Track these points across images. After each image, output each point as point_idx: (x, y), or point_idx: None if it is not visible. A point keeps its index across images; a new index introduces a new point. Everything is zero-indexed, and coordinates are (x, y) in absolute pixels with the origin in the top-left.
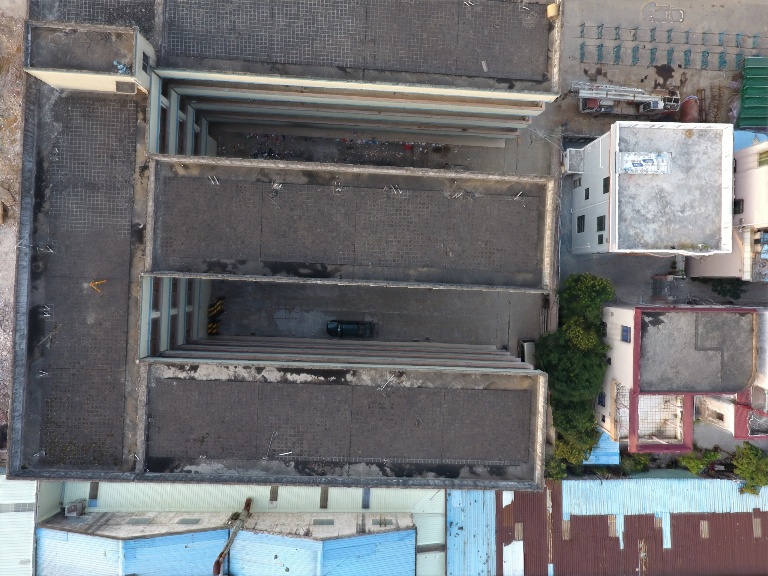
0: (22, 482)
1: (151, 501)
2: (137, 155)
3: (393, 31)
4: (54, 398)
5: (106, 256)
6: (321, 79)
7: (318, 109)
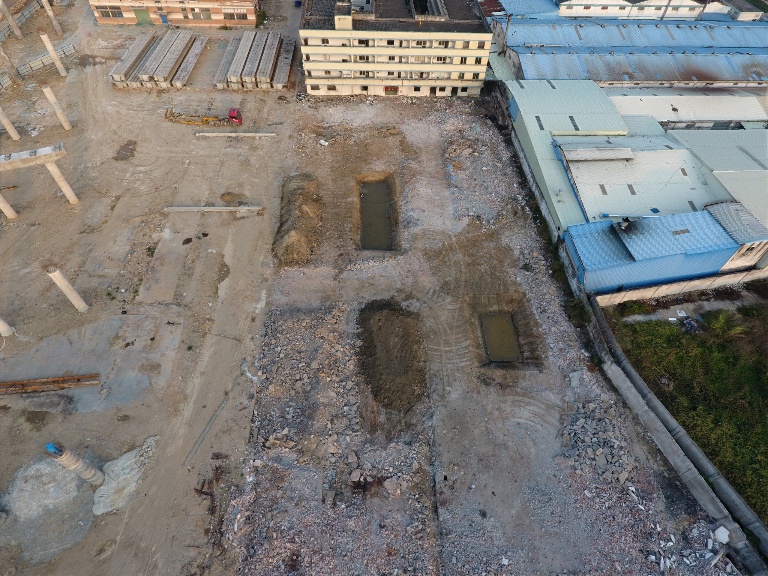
0: None
1: None
2: None
3: None
4: None
5: None
6: None
7: None
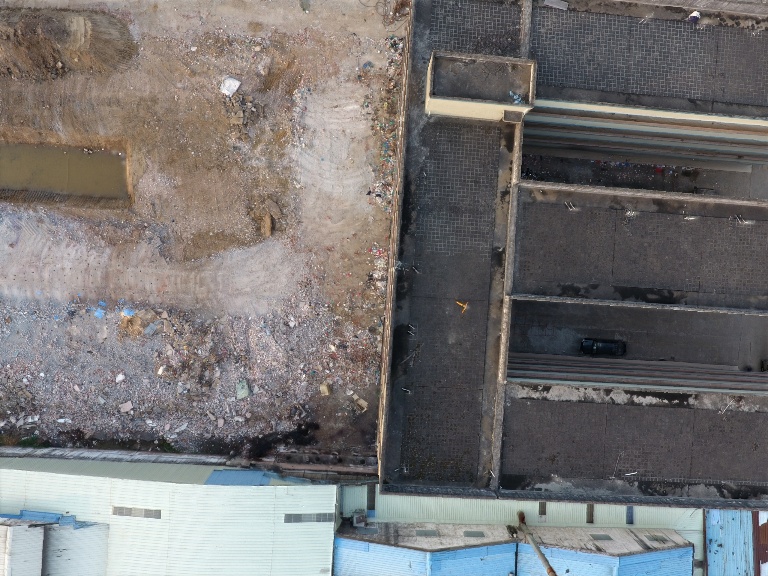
0: (324, 493)
1: (426, 513)
2: (499, 180)
3: (742, 65)
4: (416, 415)
5: (468, 278)
6: (683, 111)
7: (624, 135)
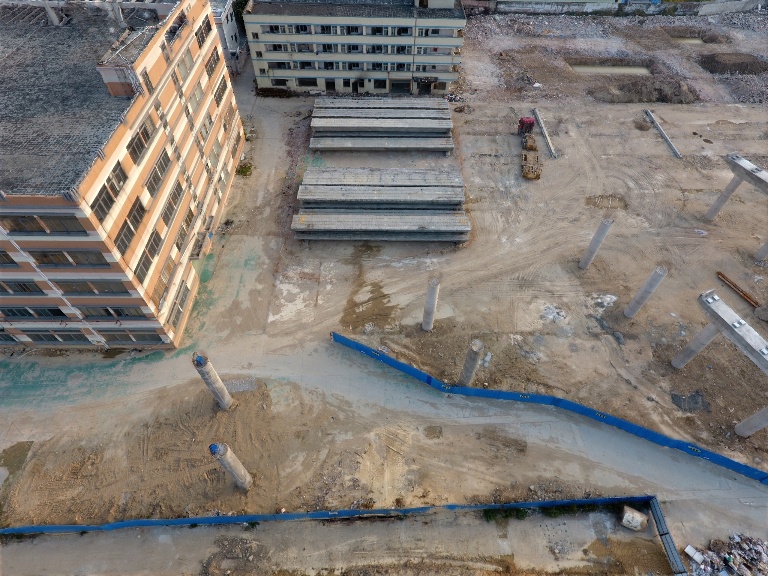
0: None
1: None
2: None
3: None
4: None
5: None
6: None
7: None
